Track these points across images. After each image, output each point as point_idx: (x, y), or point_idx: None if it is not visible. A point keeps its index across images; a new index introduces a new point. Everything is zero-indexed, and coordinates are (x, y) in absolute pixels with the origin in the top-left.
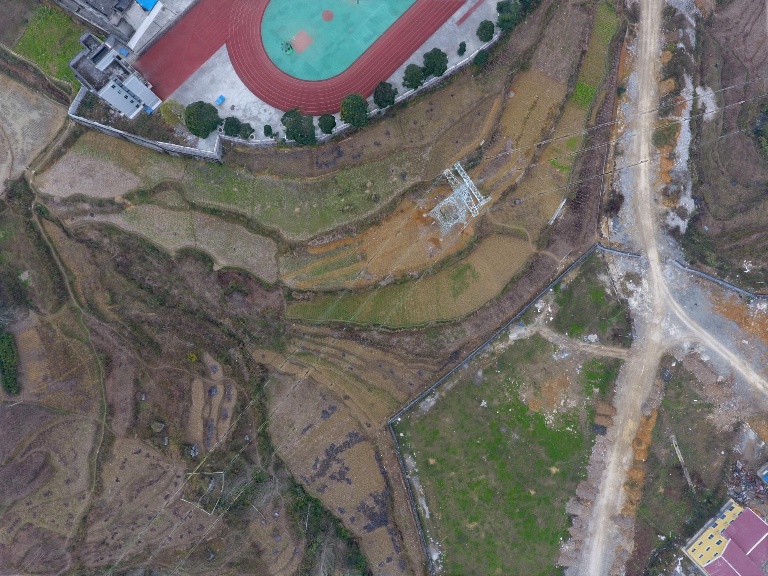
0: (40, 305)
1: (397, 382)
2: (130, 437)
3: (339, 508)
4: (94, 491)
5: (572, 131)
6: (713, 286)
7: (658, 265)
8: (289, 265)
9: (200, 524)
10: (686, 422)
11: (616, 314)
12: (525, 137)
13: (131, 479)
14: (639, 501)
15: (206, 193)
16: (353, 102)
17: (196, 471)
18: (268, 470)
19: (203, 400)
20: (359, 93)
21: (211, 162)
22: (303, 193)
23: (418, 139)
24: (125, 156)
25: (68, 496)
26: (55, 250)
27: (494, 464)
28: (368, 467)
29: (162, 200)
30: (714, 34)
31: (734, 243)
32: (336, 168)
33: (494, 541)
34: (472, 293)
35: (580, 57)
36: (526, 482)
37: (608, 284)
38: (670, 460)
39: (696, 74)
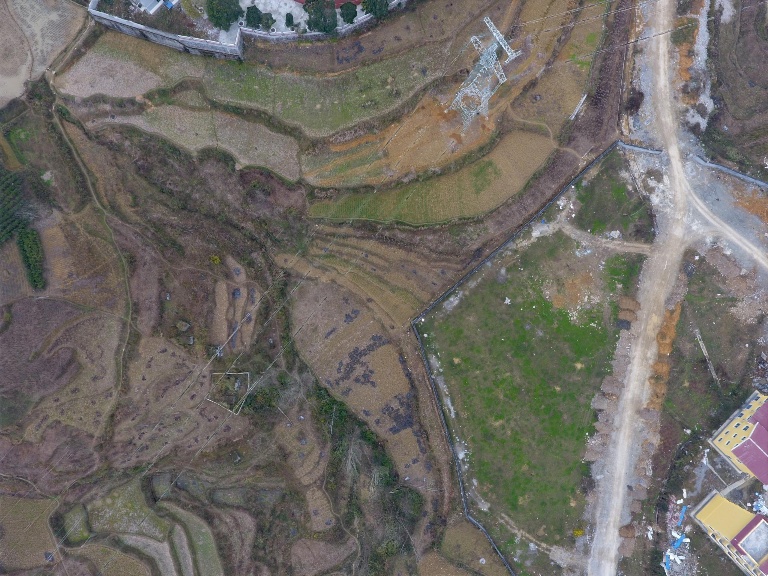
0: (63, 205)
1: (420, 282)
2: (155, 336)
3: (364, 411)
4: (121, 389)
5: (591, 27)
6: (734, 181)
7: (679, 161)
8: (311, 163)
9: (226, 425)
10: (710, 316)
11: (638, 209)
12: None
13: (157, 378)
14: (664, 395)
15: (227, 91)
16: None
17: (221, 371)
18: (292, 374)
19: (227, 302)
20: None
21: (231, 60)
22: (324, 90)
23: (438, 34)
24: (145, 56)
25: (95, 393)
26: (77, 152)
27: (519, 361)
28: (392, 370)
29: (183, 100)
30: None
31: (754, 141)
32: (357, 63)
33: (520, 438)
34: (494, 190)
35: None
36: (551, 378)
37: (629, 181)
38: (694, 354)
39: None
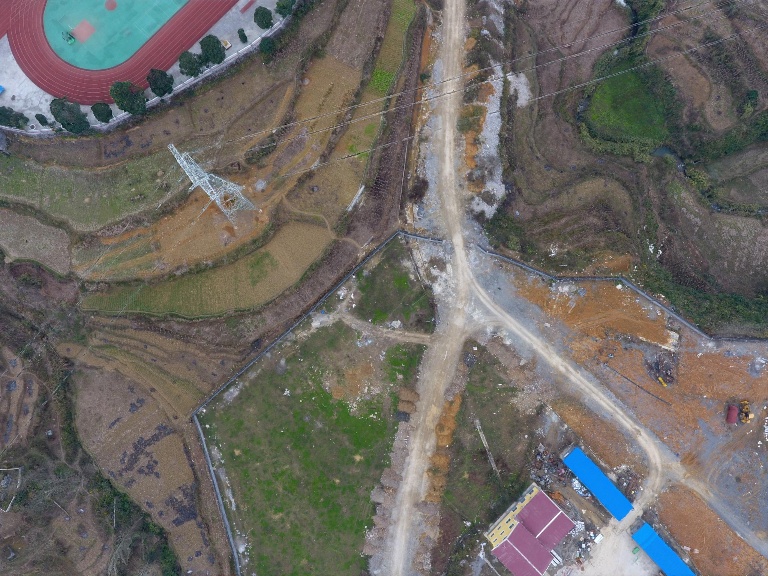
0: None
1: (200, 373)
2: None
3: (147, 502)
4: None
5: None
6: (516, 270)
7: (463, 250)
8: (81, 256)
9: None
10: (490, 406)
11: (417, 299)
12: (320, 124)
13: None
14: (443, 487)
15: None
16: (116, 89)
17: None
18: (73, 465)
19: None
20: (142, 82)
21: None
22: (93, 183)
23: (208, 127)
24: None
25: None
26: None
27: (298, 453)
28: (177, 460)
29: None
30: (529, 21)
31: (543, 227)
32: (124, 157)
33: (299, 532)
34: (271, 281)
35: (375, 44)
36: (330, 471)
37: (412, 270)
38: (475, 445)
39: (506, 60)
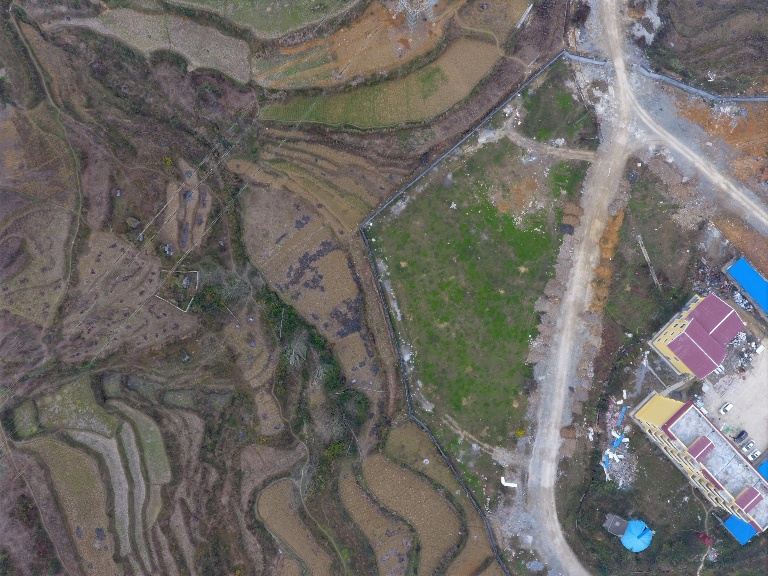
0: (17, 100)
1: (368, 186)
2: (105, 231)
3: (313, 314)
4: (70, 281)
5: None
6: (678, 92)
7: (624, 73)
8: (261, 65)
9: (175, 323)
10: (652, 223)
11: (582, 116)
12: None
13: None
14: (606, 299)
15: None
16: None
17: None
18: (243, 277)
19: (178, 202)
20: None
21: None
22: None
23: None
24: None
25: (44, 284)
26: (32, 52)
27: (464, 265)
28: (341, 275)
29: (137, 3)
30: None
31: (699, 57)
32: None
33: (464, 340)
34: (441, 95)
35: None
36: (495, 282)
37: (575, 90)
38: (636, 259)
39: None
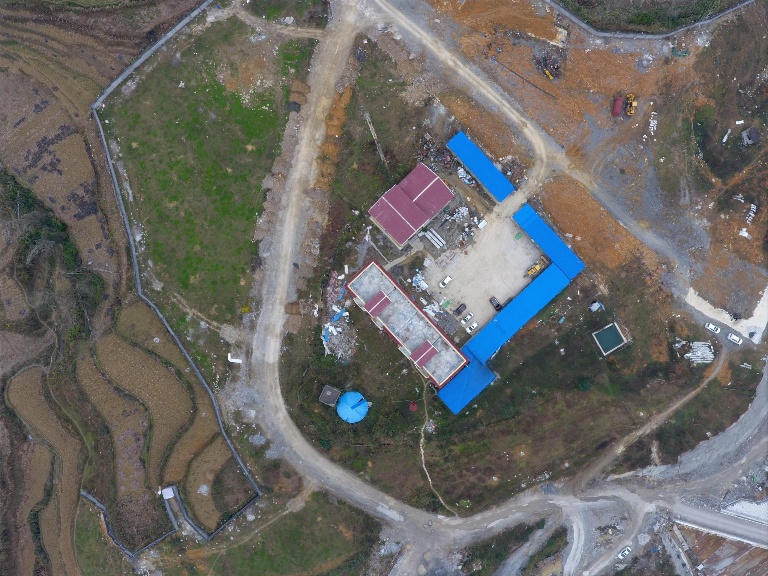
0: None
1: (99, 67)
2: None
3: (50, 197)
4: None
5: None
6: None
7: None
8: None
9: None
10: (380, 100)
11: None
12: None
13: None
14: (332, 176)
15: None
16: None
17: None
18: None
19: None
20: None
21: None
22: None
23: None
24: None
25: None
26: None
27: (192, 144)
28: (79, 158)
29: None
30: None
31: None
32: None
33: (193, 219)
34: None
35: None
36: (223, 160)
37: None
38: (364, 137)
39: None
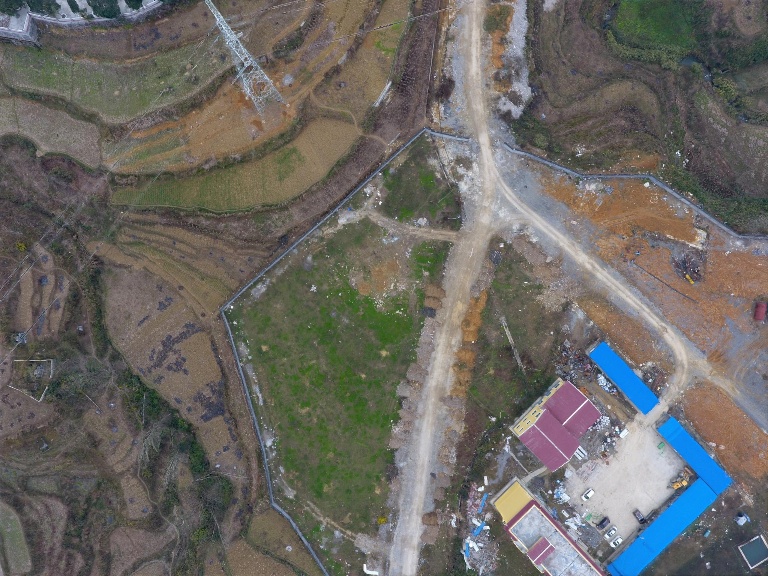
0: None
1: (228, 269)
2: None
3: (176, 398)
4: None
5: (397, 14)
6: (543, 168)
7: (489, 149)
8: (111, 150)
9: (30, 412)
10: (516, 304)
11: (444, 196)
12: (347, 19)
13: None
14: (469, 382)
15: (25, 78)
16: None
17: (24, 358)
18: (103, 361)
19: (32, 289)
20: None
21: (30, 46)
22: (122, 76)
23: (237, 20)
24: None
25: None
26: None
27: (325, 349)
28: (205, 357)
29: None
30: None
31: (570, 129)
32: (153, 50)
33: (326, 426)
34: (298, 177)
35: None
36: (356, 366)
37: (438, 168)
38: (500, 342)
39: None
